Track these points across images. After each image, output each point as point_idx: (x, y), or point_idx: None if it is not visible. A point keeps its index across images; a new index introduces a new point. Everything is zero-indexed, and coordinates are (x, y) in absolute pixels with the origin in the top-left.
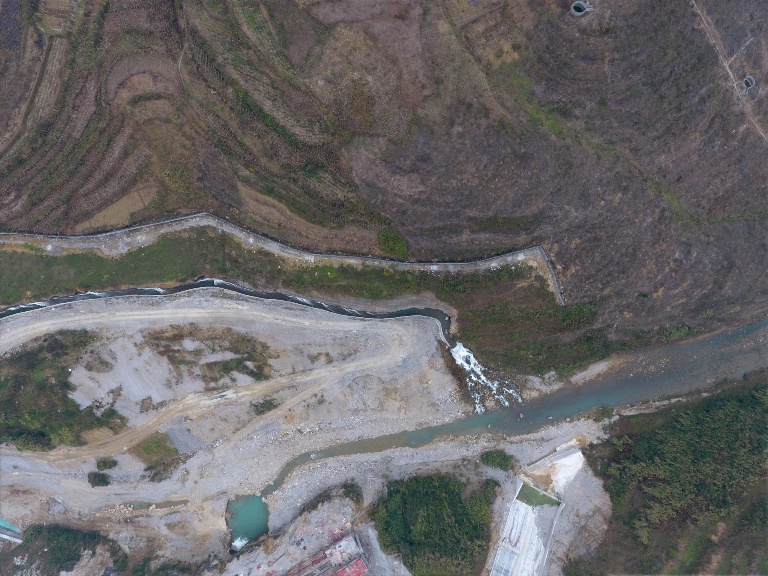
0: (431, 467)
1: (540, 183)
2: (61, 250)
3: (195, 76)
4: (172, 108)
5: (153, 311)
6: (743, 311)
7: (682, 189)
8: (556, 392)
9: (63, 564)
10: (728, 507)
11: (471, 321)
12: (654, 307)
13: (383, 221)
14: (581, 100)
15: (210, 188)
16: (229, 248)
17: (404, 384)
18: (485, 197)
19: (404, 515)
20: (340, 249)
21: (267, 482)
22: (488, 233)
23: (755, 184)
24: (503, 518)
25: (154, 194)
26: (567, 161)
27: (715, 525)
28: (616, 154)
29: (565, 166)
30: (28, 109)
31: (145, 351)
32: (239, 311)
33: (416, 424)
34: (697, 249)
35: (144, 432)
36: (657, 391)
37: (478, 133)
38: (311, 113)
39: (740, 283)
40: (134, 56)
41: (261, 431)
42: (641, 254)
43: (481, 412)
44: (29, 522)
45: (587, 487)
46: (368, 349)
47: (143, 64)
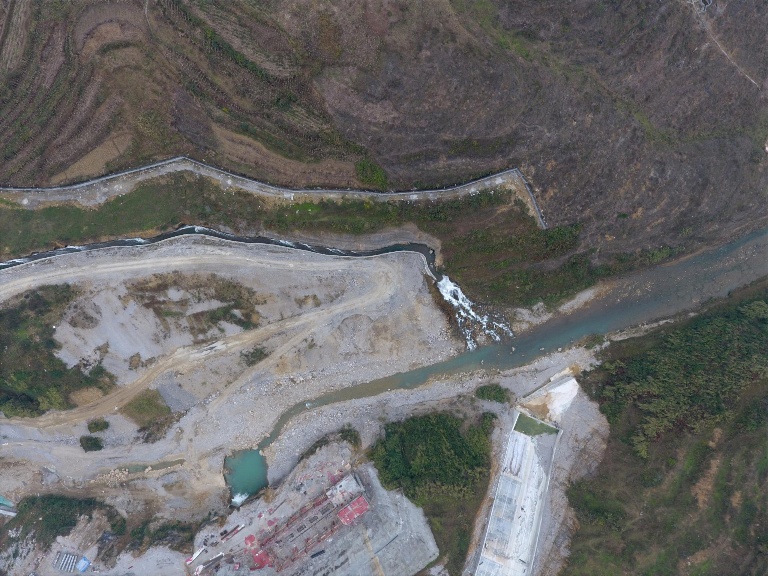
0: (427, 406)
1: (511, 103)
2: (38, 203)
3: (162, 20)
4: (141, 55)
5: (135, 261)
6: (722, 229)
7: (651, 109)
8: (546, 323)
9: (59, 529)
10: (723, 412)
11: (455, 251)
12: (634, 228)
13: (359, 151)
14: (545, 21)
15: (184, 132)
16: (208, 192)
17: (393, 321)
18: (458, 119)
19: (403, 453)
20: (319, 184)
21: (263, 434)
22: (464, 158)
23: (722, 102)
24: (502, 448)
25: (128, 141)
26: (536, 82)
27: (711, 431)
28: (584, 74)
29: (534, 86)
30: None
31: (130, 304)
32: (222, 257)
33: (409, 365)
34: (671, 167)
35: (134, 390)
36: (645, 315)
37: (446, 56)
38: (280, 47)
39: (716, 199)
40: (100, 6)
41: (254, 383)
42: (617, 174)
43: (473, 348)
44: (22, 494)
45: (584, 412)
46: (355, 289)
47: (109, 13)
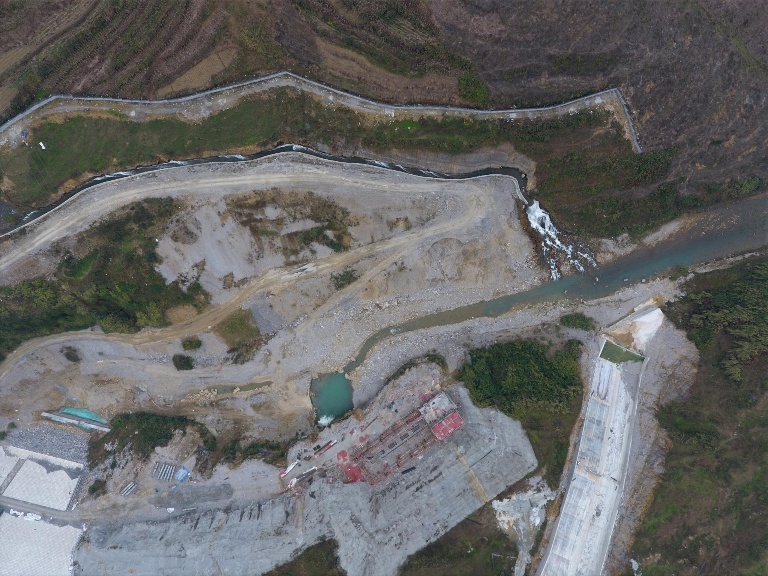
0: (512, 334)
1: (617, 18)
2: (144, 116)
3: None
4: None
5: (236, 177)
6: None
7: (749, 33)
8: (630, 254)
9: (157, 441)
10: None
11: (549, 174)
12: (726, 156)
13: (464, 65)
14: None
15: (288, 46)
16: (309, 108)
17: (484, 244)
18: (565, 33)
19: (492, 375)
20: (420, 100)
21: (349, 358)
22: (566, 76)
23: None
24: (590, 373)
25: (234, 54)
26: None
27: None
28: None
29: (639, 3)
30: None
31: (228, 221)
32: (319, 176)
33: (493, 293)
34: (766, 95)
35: (227, 310)
36: (730, 248)
37: None
38: None
39: None
40: None
41: (341, 307)
42: (712, 99)
43: (557, 278)
44: (115, 412)
45: (670, 340)
46: (446, 212)
47: None
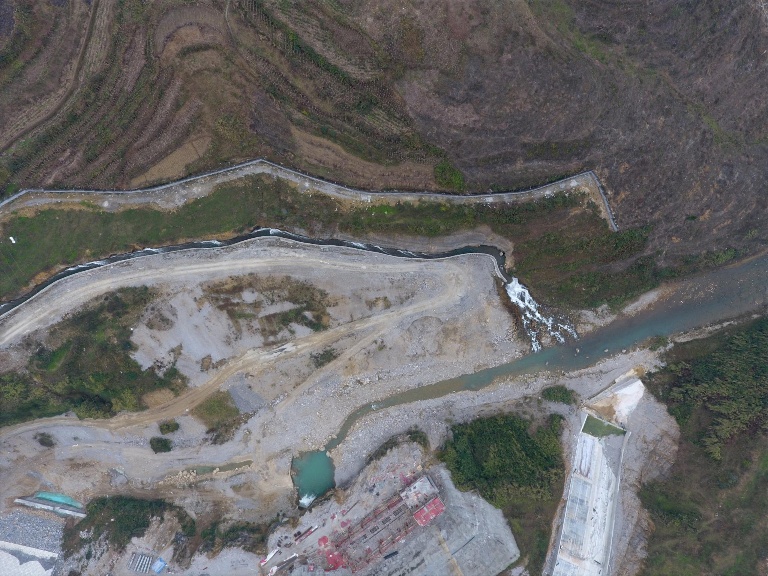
0: (493, 408)
1: (590, 106)
2: (118, 206)
3: (243, 24)
4: (221, 58)
5: (212, 264)
6: None
7: (720, 111)
8: (610, 325)
9: (133, 531)
10: None
11: (527, 253)
12: (701, 230)
13: (439, 154)
14: (621, 24)
15: (263, 135)
16: (285, 194)
17: (464, 323)
18: (538, 122)
19: (474, 454)
20: (396, 186)
21: (330, 436)
22: (541, 161)
23: None
24: (572, 450)
25: (208, 143)
26: (612, 85)
27: None
28: (657, 77)
29: (611, 89)
30: (79, 65)
31: (205, 306)
32: (297, 259)
33: (474, 367)
34: (739, 170)
35: (205, 392)
36: (708, 316)
37: (527, 59)
38: (362, 50)
39: None
40: (180, 9)
41: (321, 384)
42: (686, 177)
43: (538, 350)
44: (91, 496)
45: (651, 414)
46: (425, 290)
47: (189, 16)
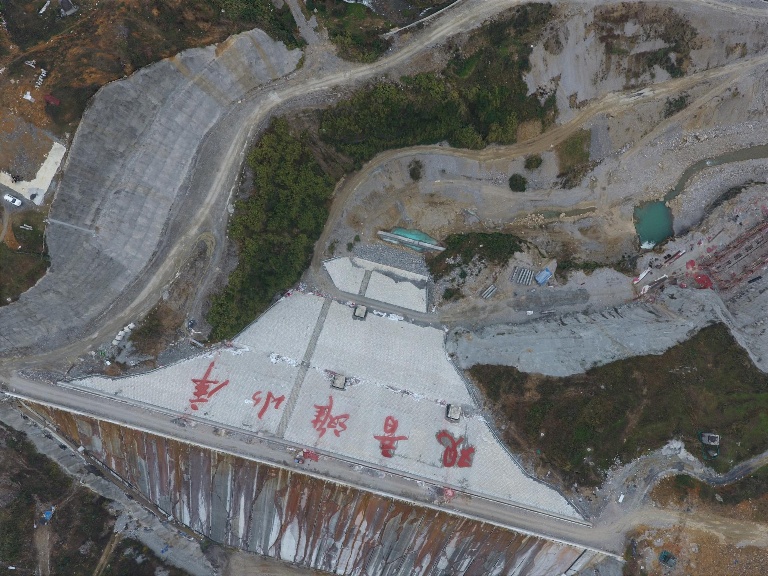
0: None
1: None
2: None
3: None
4: None
5: None
6: None
7: None
8: None
9: (513, 248)
10: None
11: None
12: None
13: None
14: None
15: None
16: None
17: None
18: None
19: None
20: None
21: (671, 186)
22: None
23: None
24: None
25: None
26: None
27: None
28: None
29: None
30: None
31: (590, 35)
32: None
33: None
34: None
35: (569, 130)
36: None
37: None
38: None
39: None
40: None
41: (665, 136)
42: None
43: None
44: (446, 233)
45: None
46: None
47: None
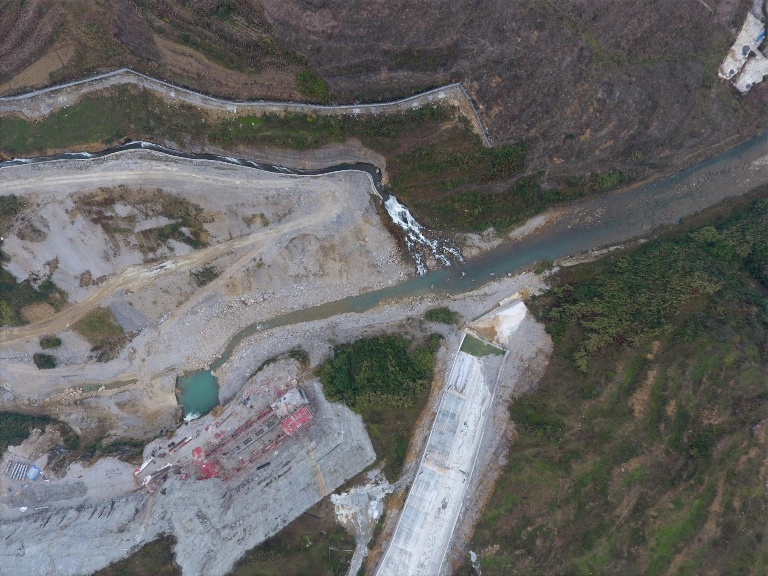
0: (377, 329)
1: (451, 13)
2: None
3: None
4: None
5: (81, 175)
6: (674, 156)
7: (599, 28)
8: (496, 249)
9: (11, 440)
10: (662, 326)
11: (400, 169)
12: (582, 150)
13: (299, 61)
14: None
15: (127, 43)
16: (152, 105)
17: (340, 240)
18: (397, 28)
19: (349, 370)
20: (261, 96)
21: (215, 355)
22: (406, 71)
23: (673, 24)
24: (448, 366)
25: (71, 51)
26: None
27: (650, 344)
28: None
29: None
30: None
31: (78, 219)
32: (169, 172)
33: (360, 289)
34: (619, 89)
35: (86, 308)
36: (595, 241)
37: None
38: None
39: (666, 123)
40: None
41: (205, 304)
42: (563, 94)
43: (423, 273)
44: None
45: (530, 333)
46: (302, 208)
47: None
